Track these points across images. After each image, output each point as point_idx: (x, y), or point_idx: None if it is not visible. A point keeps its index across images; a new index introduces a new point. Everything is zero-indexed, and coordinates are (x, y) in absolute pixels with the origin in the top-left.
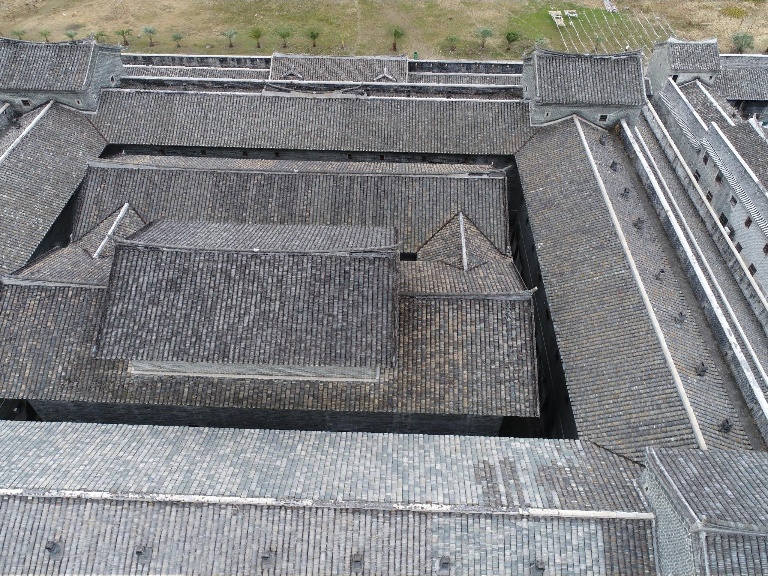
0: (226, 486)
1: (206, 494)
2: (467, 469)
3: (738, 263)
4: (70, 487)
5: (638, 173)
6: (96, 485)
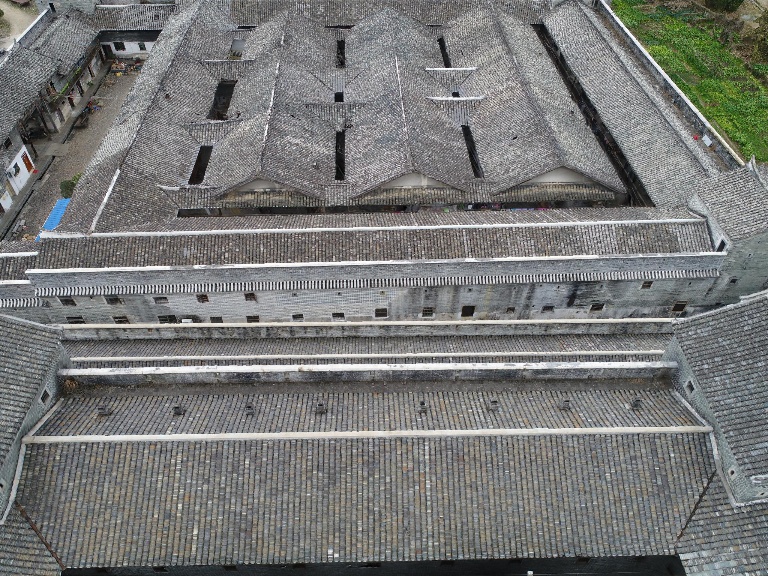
0: None
1: None
2: None
3: (273, 328)
4: None
5: (188, 383)
6: None
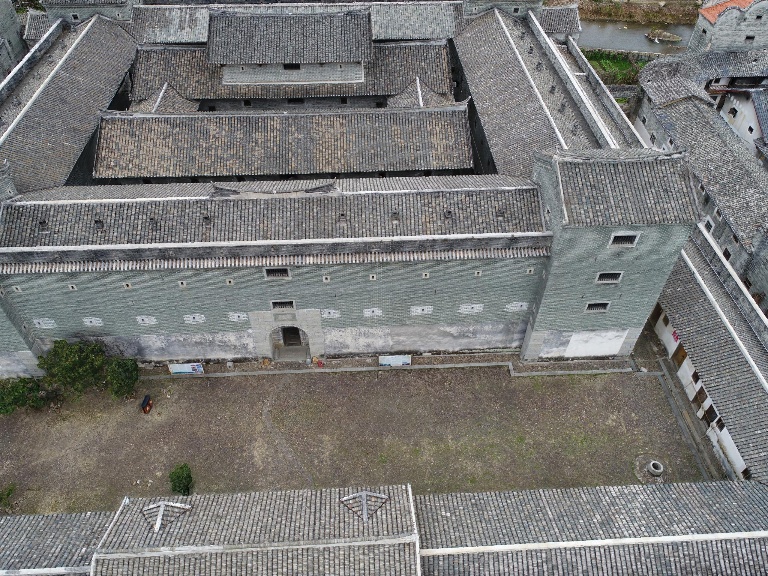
0: (298, 11)
1: (304, 7)
2: (200, 24)
3: None
4: (357, 7)
5: None
6: (348, 8)
